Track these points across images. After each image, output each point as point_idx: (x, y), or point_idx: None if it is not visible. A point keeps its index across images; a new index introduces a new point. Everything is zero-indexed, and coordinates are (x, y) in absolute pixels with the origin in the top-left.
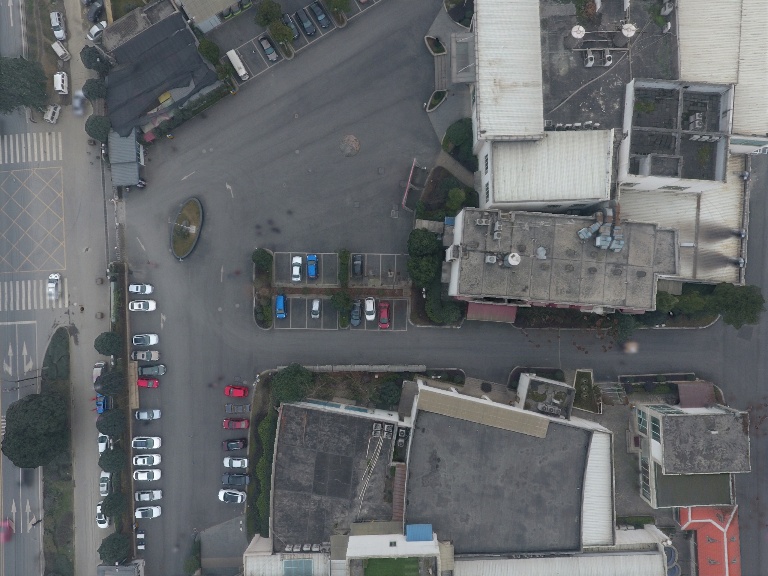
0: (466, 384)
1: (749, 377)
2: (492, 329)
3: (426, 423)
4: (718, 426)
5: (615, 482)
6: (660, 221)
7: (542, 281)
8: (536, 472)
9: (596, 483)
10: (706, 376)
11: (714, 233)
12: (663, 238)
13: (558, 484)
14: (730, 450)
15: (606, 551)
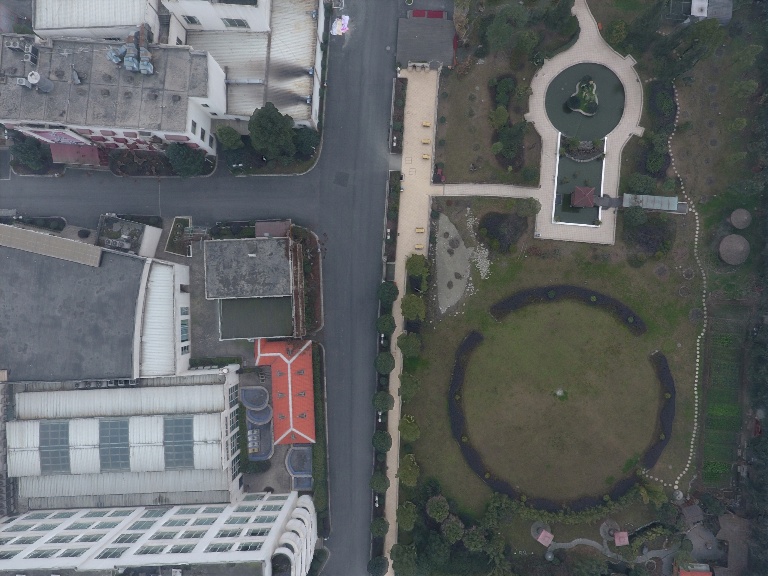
0: (64, 230)
1: (345, 223)
2: (94, 178)
3: None
4: (261, 251)
5: (205, 324)
6: (234, 61)
7: (79, 106)
8: (93, 302)
9: (159, 315)
10: (302, 222)
11: (285, 71)
12: (199, 63)
13: (115, 313)
14: (272, 274)
15: (177, 385)
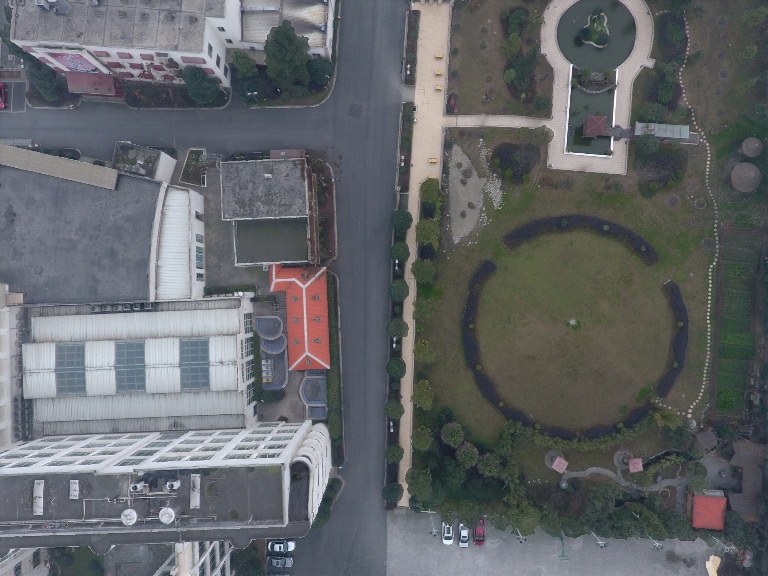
0: None
1: (358, 154)
2: (108, 110)
3: (2, 179)
4: (277, 172)
5: (220, 253)
6: None
7: (97, 27)
8: (109, 225)
9: (174, 239)
10: (316, 153)
11: None
12: None
13: (130, 237)
14: (288, 196)
15: None
